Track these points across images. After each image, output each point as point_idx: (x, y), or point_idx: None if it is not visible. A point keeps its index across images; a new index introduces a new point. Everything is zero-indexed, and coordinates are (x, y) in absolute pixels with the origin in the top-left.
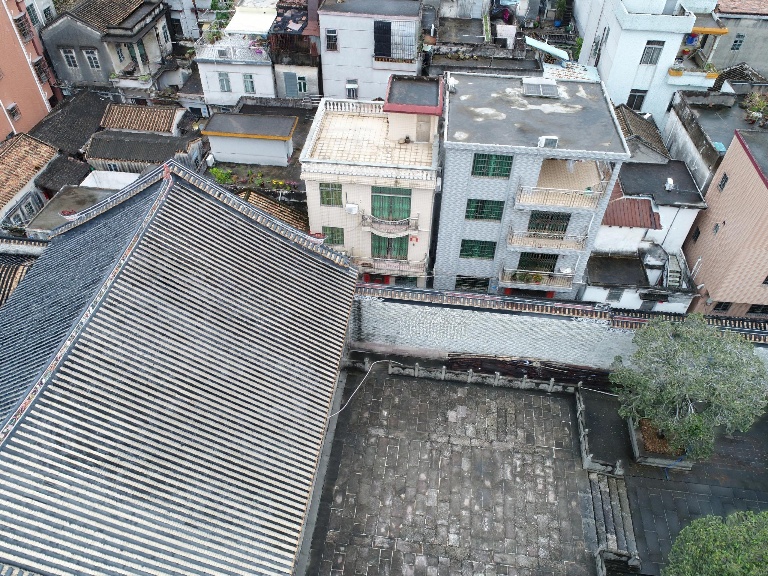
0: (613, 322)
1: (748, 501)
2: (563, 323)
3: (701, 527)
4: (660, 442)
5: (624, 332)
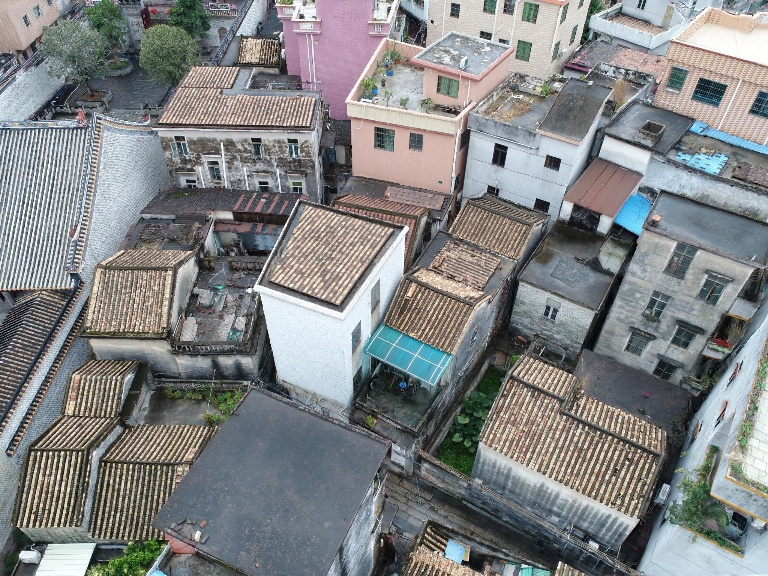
0: (25, 69)
1: (133, 84)
2: (15, 85)
3: (143, 52)
4: (96, 97)
5: (32, 72)
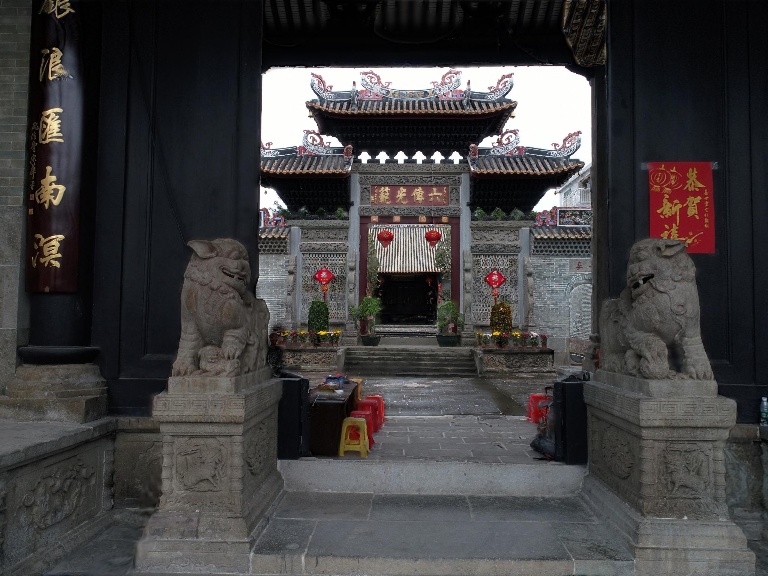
0: None
1: None
2: None
3: None
4: None
5: None
